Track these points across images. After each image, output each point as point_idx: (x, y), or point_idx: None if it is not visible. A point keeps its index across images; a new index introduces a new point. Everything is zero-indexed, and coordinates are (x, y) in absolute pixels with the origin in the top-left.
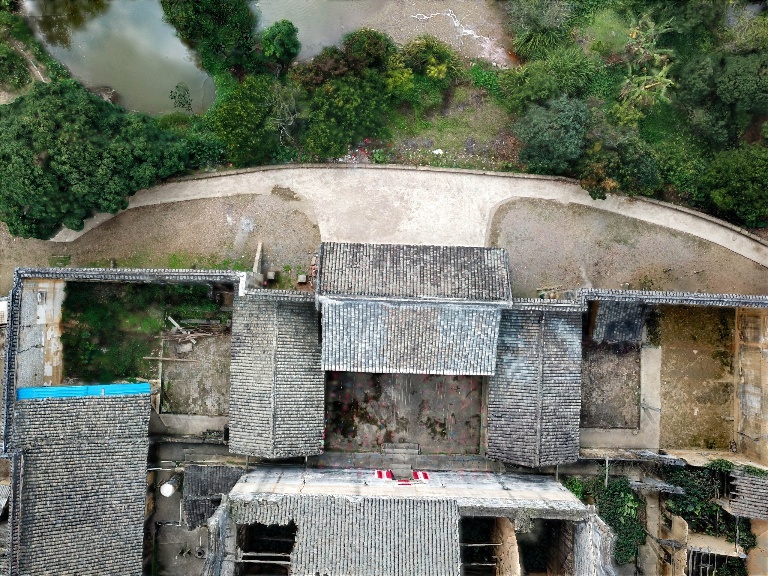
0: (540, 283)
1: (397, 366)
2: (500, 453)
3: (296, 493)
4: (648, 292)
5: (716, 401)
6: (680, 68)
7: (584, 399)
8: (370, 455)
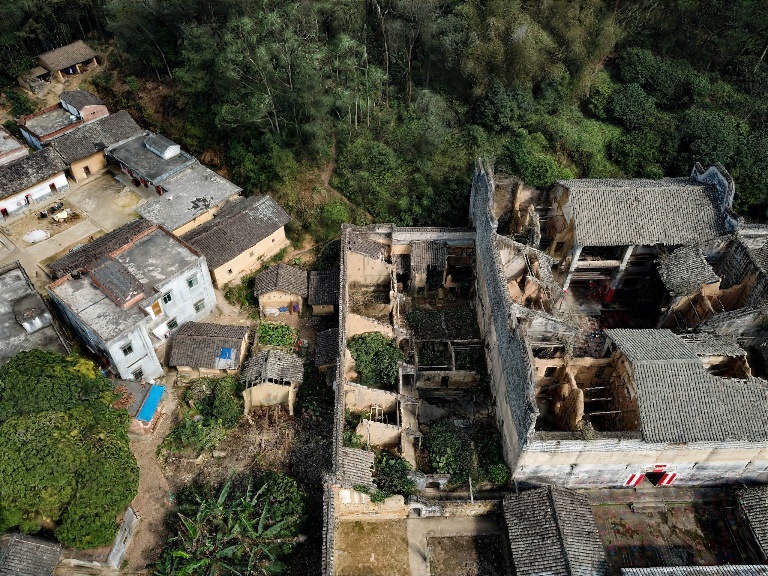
0: None
1: (721, 573)
2: (579, 499)
3: (767, 448)
4: None
5: (353, 569)
6: None
7: (486, 565)
8: (677, 499)
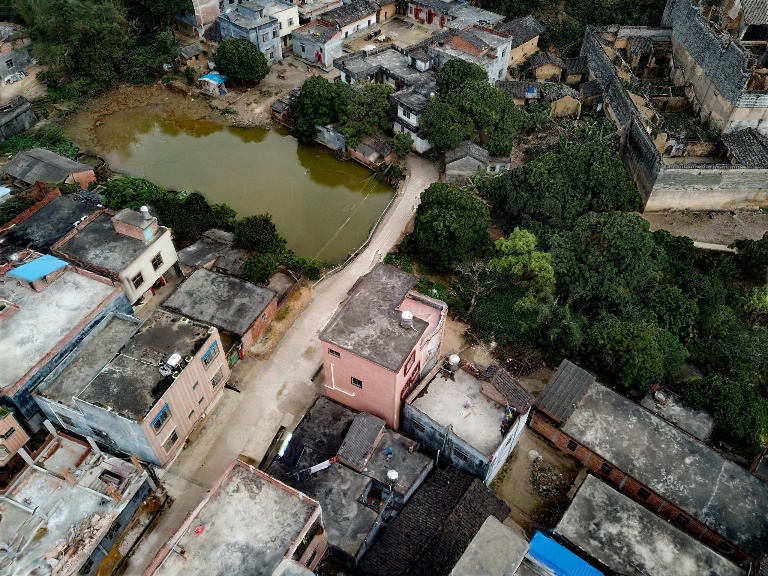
0: (765, 217)
1: None
2: (765, 137)
3: None
4: (748, 167)
5: None
6: (734, 328)
7: None
8: None
